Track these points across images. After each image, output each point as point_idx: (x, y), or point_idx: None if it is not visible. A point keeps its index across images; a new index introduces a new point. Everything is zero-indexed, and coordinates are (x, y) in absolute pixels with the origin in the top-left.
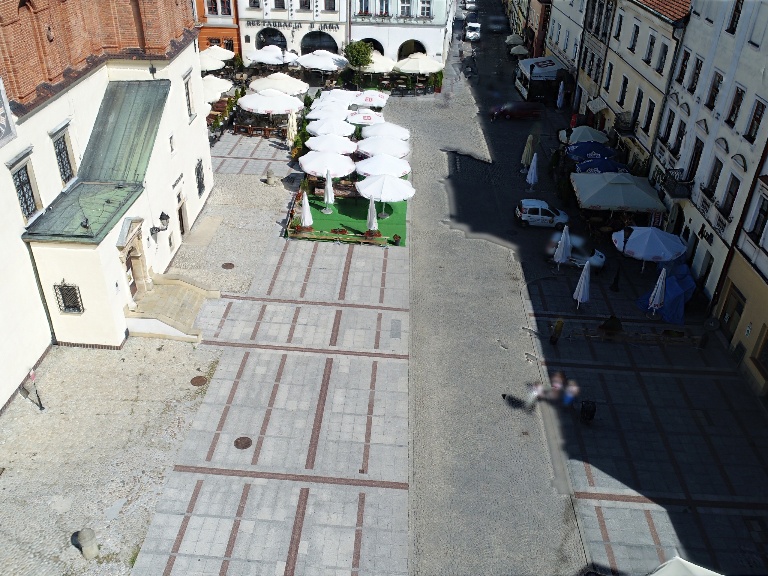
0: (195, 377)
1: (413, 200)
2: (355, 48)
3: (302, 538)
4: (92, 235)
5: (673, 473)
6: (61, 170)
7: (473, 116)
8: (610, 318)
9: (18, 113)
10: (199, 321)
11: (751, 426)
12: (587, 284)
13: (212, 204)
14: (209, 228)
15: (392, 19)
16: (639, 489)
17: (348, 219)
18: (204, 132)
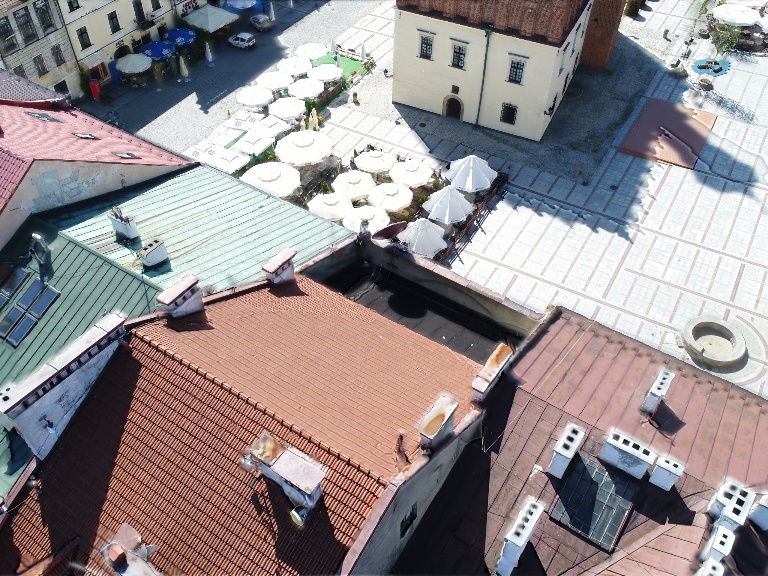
0: None
1: None
2: None
3: None
4: None
5: None
6: None
7: None
8: None
9: None
10: None
11: None
12: None
13: None
14: None
15: None
16: None
17: None
18: None
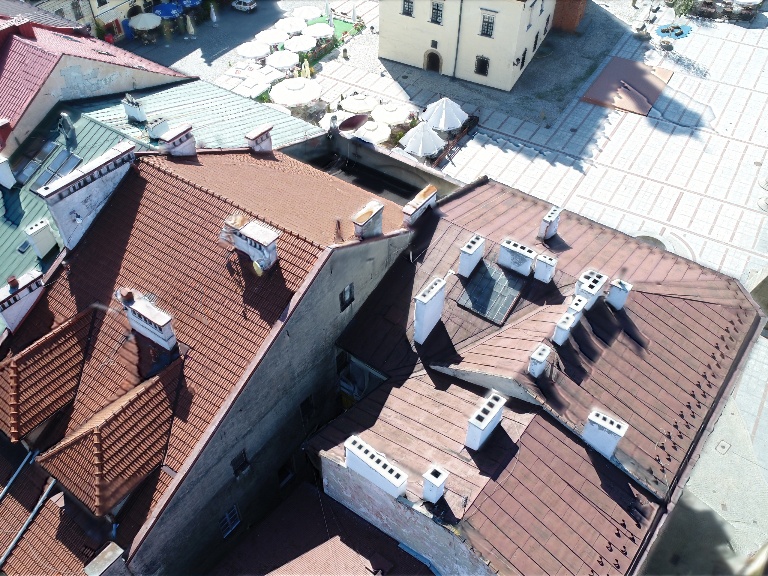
0: None
1: None
2: None
3: None
4: None
5: None
6: None
7: None
8: None
9: None
10: None
11: None
12: None
13: None
14: None
15: None
16: None
17: None
18: None
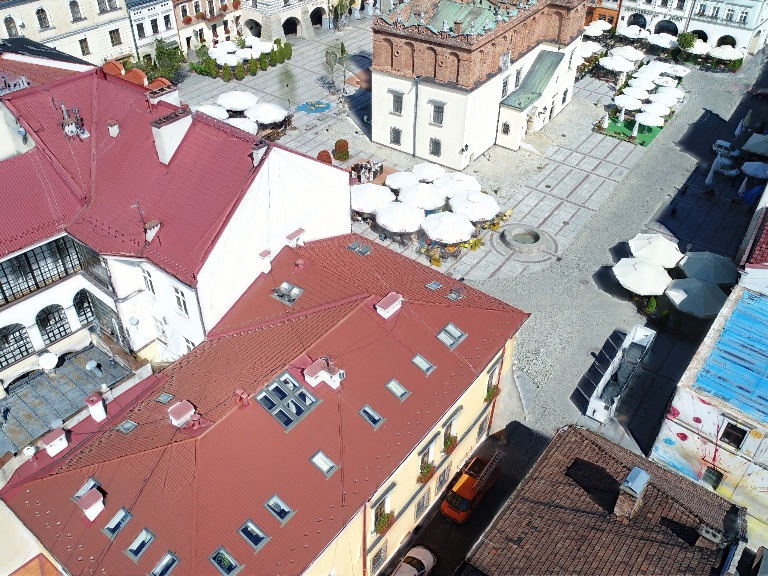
0: (539, 166)
1: (666, 129)
2: (684, 37)
3: (557, 210)
4: (521, 108)
5: (692, 235)
6: (515, 83)
7: (743, 92)
8: (711, 190)
9: (512, 62)
10: (546, 151)
11: (739, 235)
12: (711, 176)
13: (567, 110)
14: (562, 119)
15: (719, 20)
16: (675, 234)
17: (627, 130)
18: (574, 76)
